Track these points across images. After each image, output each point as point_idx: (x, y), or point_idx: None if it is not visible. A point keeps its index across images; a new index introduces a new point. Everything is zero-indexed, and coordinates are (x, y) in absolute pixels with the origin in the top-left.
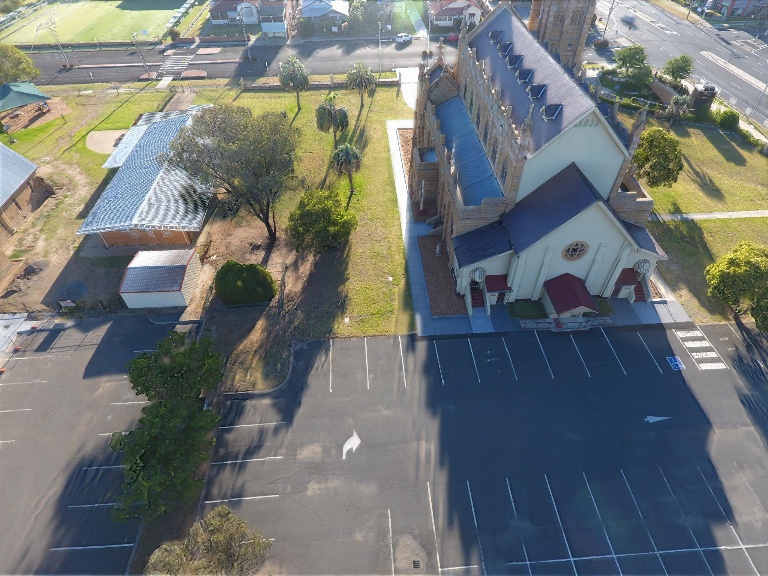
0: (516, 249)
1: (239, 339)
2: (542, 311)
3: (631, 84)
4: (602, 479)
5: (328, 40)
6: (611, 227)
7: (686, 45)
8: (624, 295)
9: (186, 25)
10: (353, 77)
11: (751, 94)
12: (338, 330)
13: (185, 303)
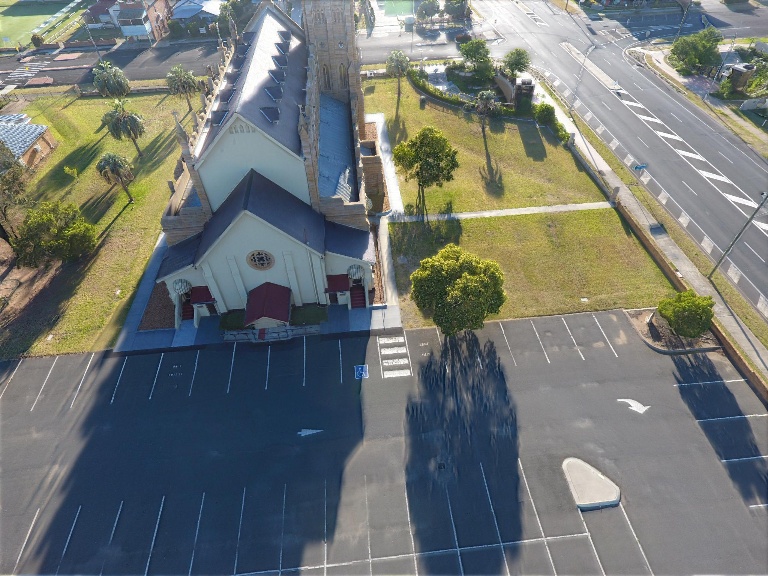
0: (194, 260)
1: None
2: None
3: (476, 79)
4: (219, 499)
5: (195, 42)
6: (280, 235)
7: (549, 36)
8: (344, 301)
9: None
10: None
11: (587, 86)
12: (34, 349)
13: None
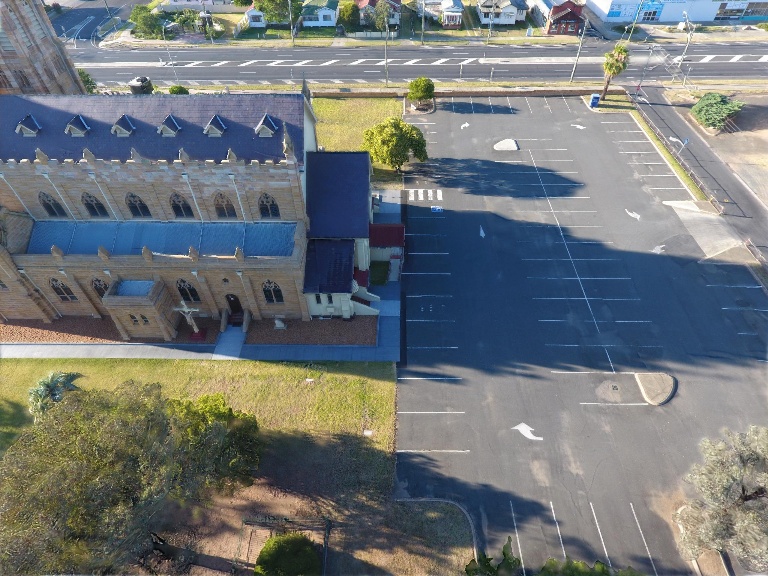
0: (362, 236)
1: None
2: (381, 263)
3: None
4: (530, 270)
5: None
6: None
7: None
8: None
9: None
10: None
11: (145, 73)
12: (383, 443)
13: None
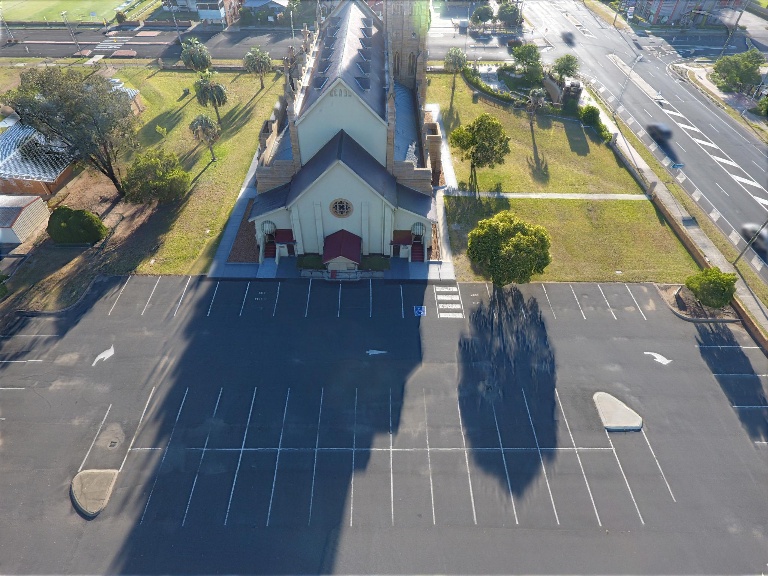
0: (286, 203)
1: (51, 271)
2: None
3: (525, 80)
4: (302, 394)
5: (263, 29)
6: (363, 186)
7: (597, 48)
8: (405, 255)
9: (139, 10)
10: (251, 60)
11: (631, 94)
12: (140, 269)
13: (19, 240)
